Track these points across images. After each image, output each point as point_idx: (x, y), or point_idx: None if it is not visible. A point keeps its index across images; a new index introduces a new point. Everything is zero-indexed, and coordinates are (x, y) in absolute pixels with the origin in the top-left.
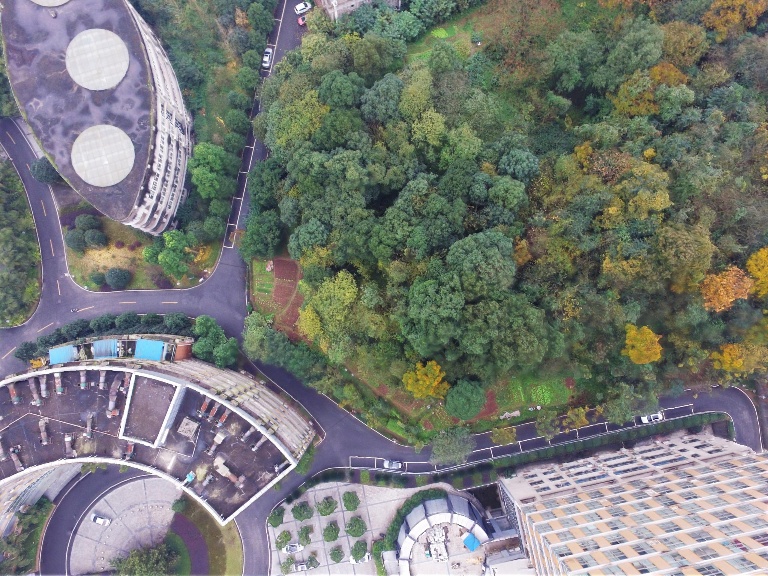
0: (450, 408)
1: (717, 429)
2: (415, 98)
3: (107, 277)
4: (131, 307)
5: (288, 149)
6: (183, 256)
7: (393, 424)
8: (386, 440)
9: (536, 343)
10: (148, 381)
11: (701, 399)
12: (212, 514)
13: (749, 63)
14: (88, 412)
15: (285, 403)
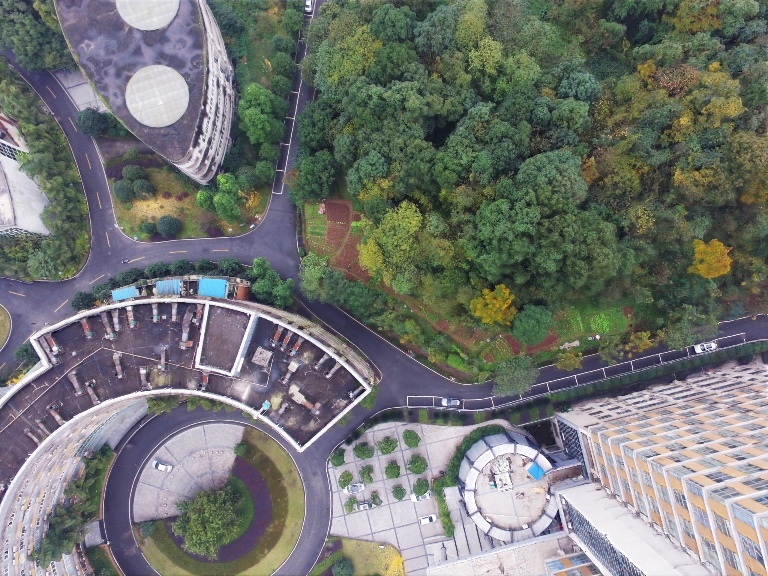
0: (518, 332)
1: (767, 358)
2: (472, 26)
3: (159, 225)
4: (182, 256)
5: (341, 86)
6: (235, 201)
7: (453, 359)
8: (443, 379)
9: (611, 255)
10: (221, 311)
11: (753, 328)
12: (290, 441)
13: None
14: (161, 345)
15: (343, 343)
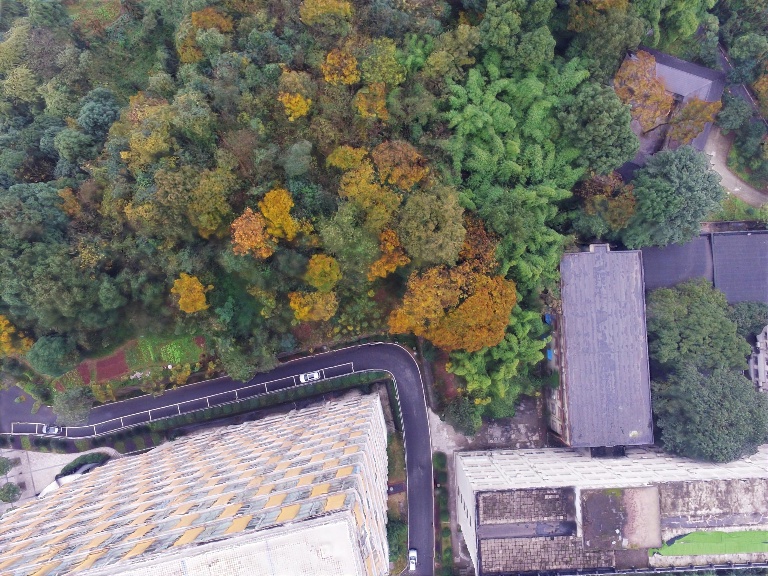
0: None
1: (389, 388)
2: (2, 54)
3: None
4: None
5: None
6: None
7: (28, 387)
8: (47, 405)
9: (53, 291)
10: None
11: (361, 357)
12: None
13: (294, 6)
14: None
15: None
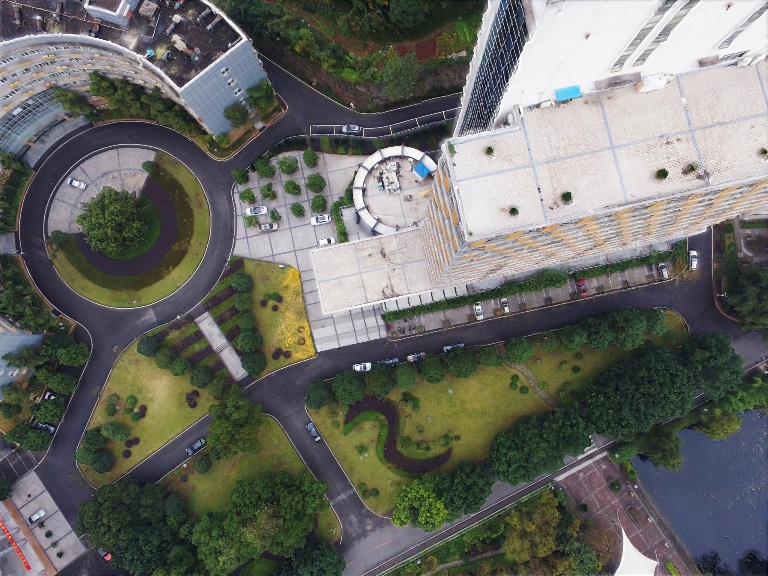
0: (392, 4)
1: None
2: None
3: None
4: None
5: None
6: None
7: (347, 70)
8: (344, 109)
9: None
10: None
11: None
12: (169, 82)
13: None
14: None
15: None
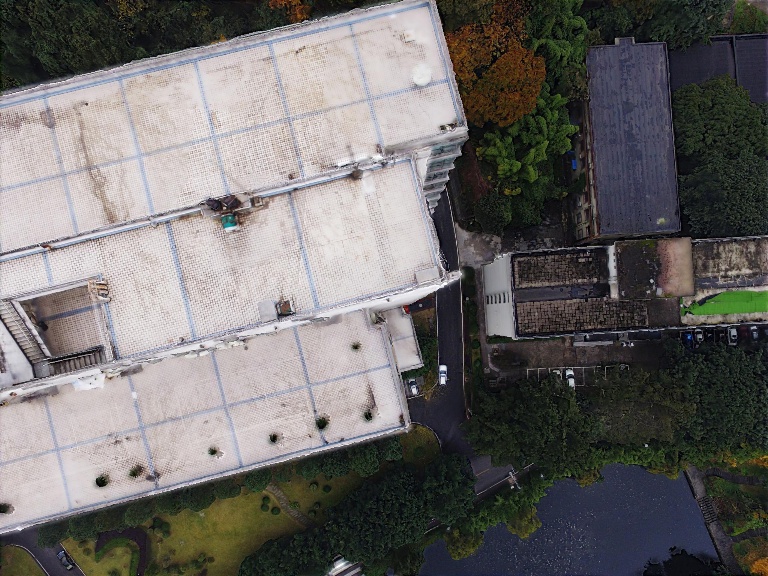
0: None
1: None
2: None
3: None
4: None
5: None
6: None
7: None
8: None
9: (92, 43)
10: None
11: None
12: None
13: None
14: None
15: None
